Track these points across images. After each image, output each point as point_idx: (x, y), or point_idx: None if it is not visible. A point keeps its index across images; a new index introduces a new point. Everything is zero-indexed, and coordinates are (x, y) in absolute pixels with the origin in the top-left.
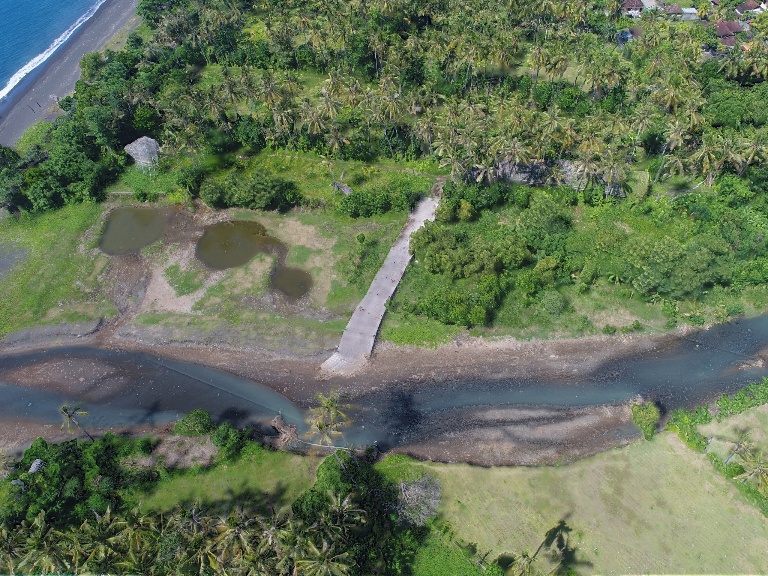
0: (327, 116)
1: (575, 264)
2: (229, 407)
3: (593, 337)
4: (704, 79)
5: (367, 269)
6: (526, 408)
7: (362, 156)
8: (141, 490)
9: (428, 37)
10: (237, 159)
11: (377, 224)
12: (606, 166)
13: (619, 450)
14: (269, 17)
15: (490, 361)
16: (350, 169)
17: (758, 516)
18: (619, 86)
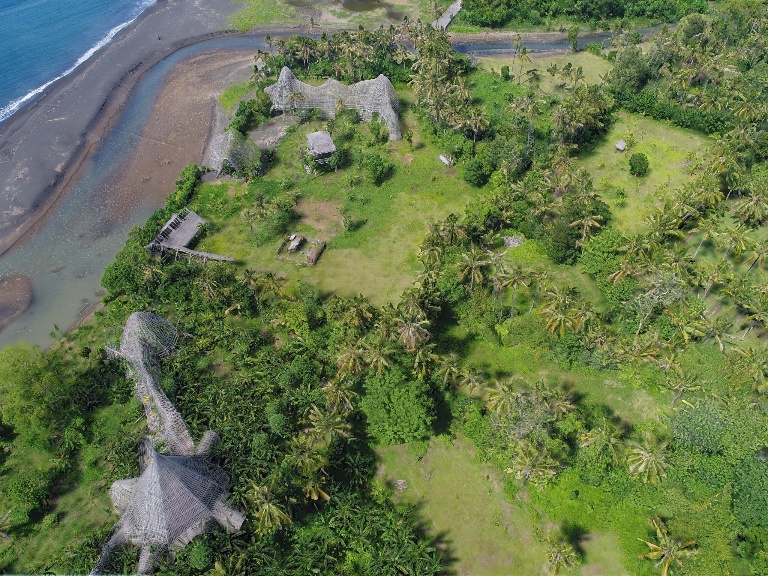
0: None
1: (547, 5)
2: None
3: (554, 33)
4: None
5: None
6: None
7: None
8: None
9: None
10: None
11: None
12: None
13: (562, 55)
14: None
15: (503, 38)
16: None
17: None
18: None
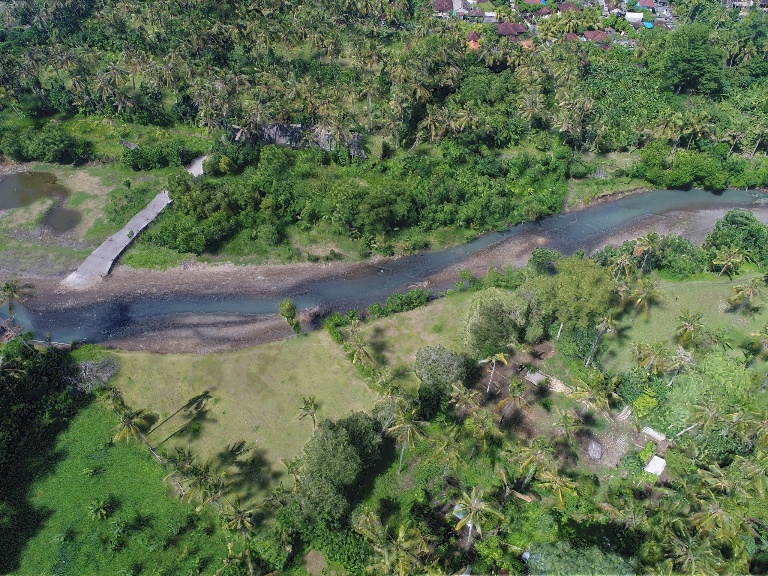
0: None
1: (298, 206)
2: None
3: (299, 264)
4: (467, 67)
5: (129, 210)
6: (220, 315)
7: (158, 122)
8: None
9: (230, 23)
10: (50, 122)
11: (154, 176)
12: (333, 127)
13: (276, 342)
14: (102, 3)
15: (206, 280)
16: (146, 132)
17: (364, 388)
18: (384, 68)
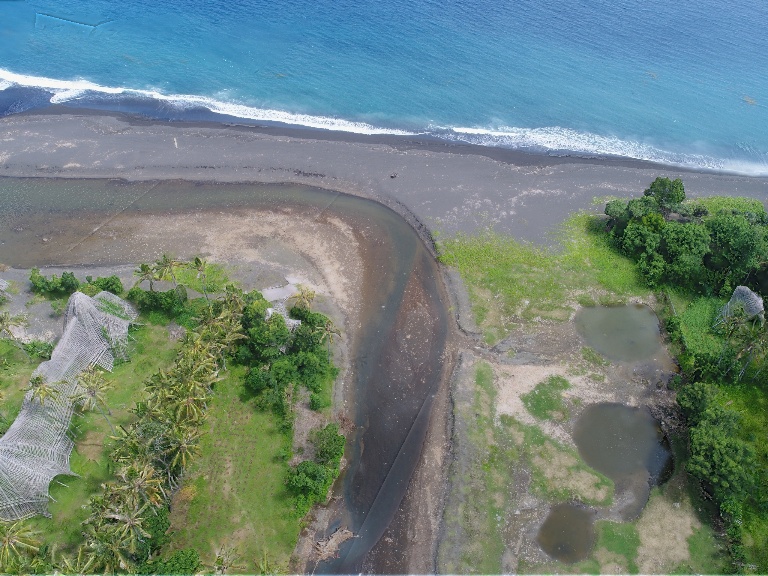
0: None
1: None
2: (368, 477)
3: None
4: None
5: None
6: None
7: None
8: (275, 410)
9: None
10: None
11: None
12: None
13: None
14: None
15: None
16: None
17: None
18: None
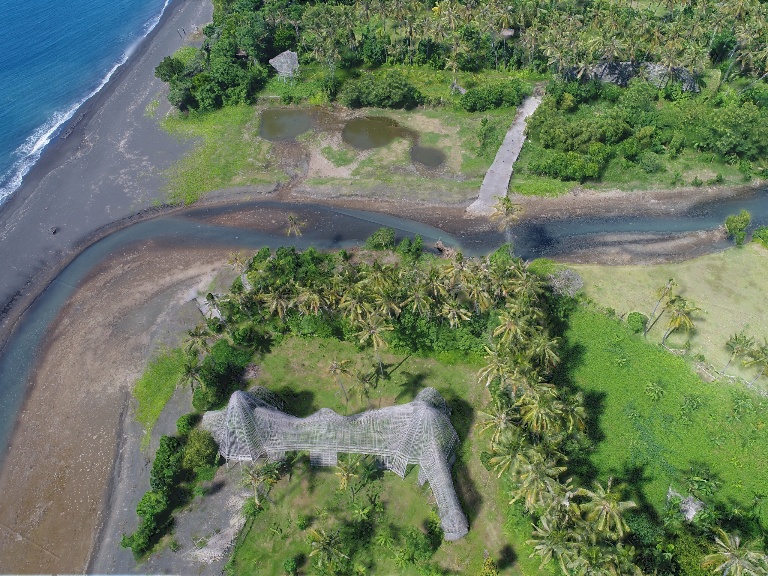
0: (448, 28)
1: (665, 136)
2: (398, 237)
3: (684, 188)
4: None
5: (491, 145)
6: (636, 233)
7: (471, 67)
8: None
9: None
10: (362, 72)
11: (491, 116)
12: (689, 59)
13: (716, 254)
14: None
15: (602, 205)
16: (461, 78)
17: None
18: (689, 7)
